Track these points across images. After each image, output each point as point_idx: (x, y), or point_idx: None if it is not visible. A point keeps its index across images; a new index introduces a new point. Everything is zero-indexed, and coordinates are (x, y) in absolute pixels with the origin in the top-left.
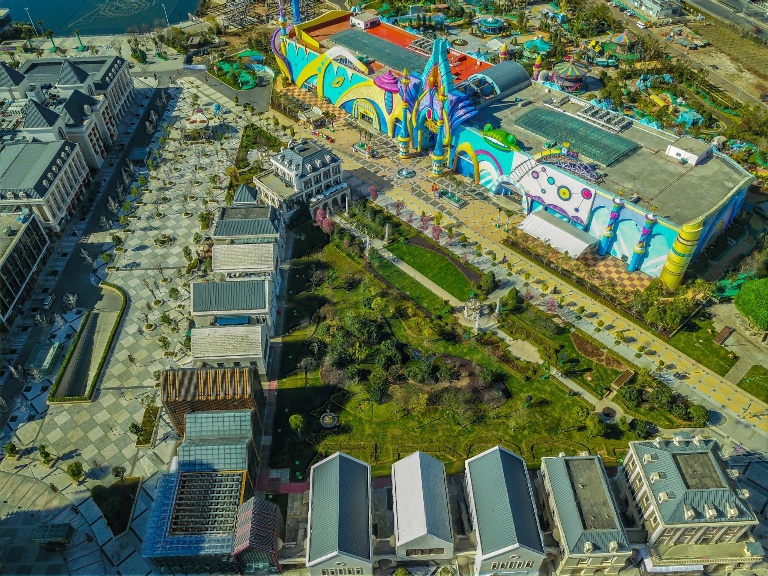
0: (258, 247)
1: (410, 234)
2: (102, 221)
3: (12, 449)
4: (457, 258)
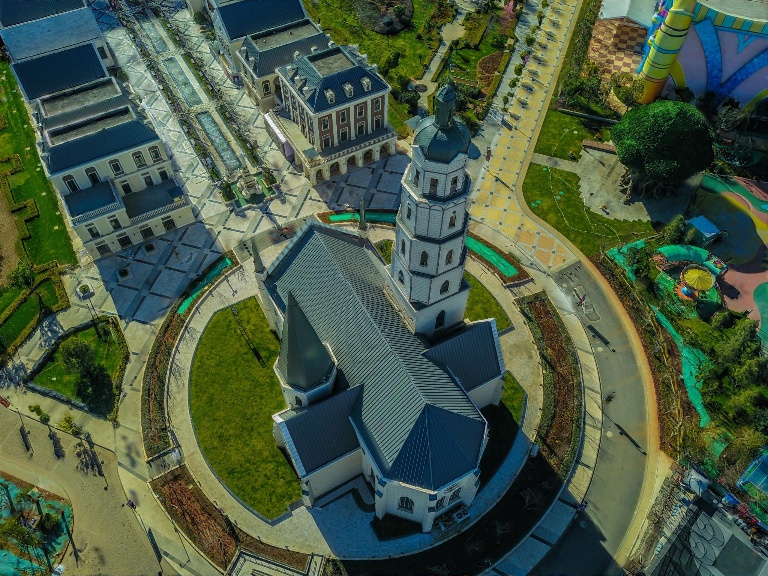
0: None
1: None
2: None
3: None
4: None
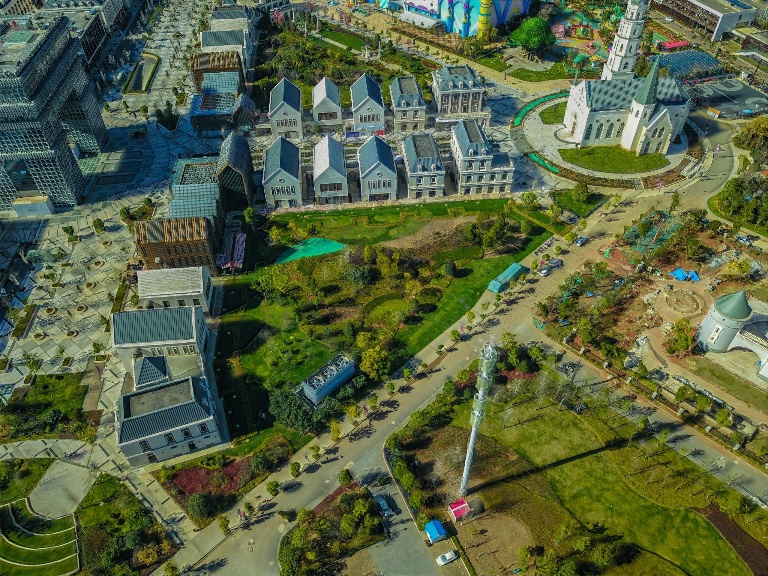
0: (238, 20)
1: (333, 27)
2: (138, 24)
3: (107, 106)
4: (360, 35)
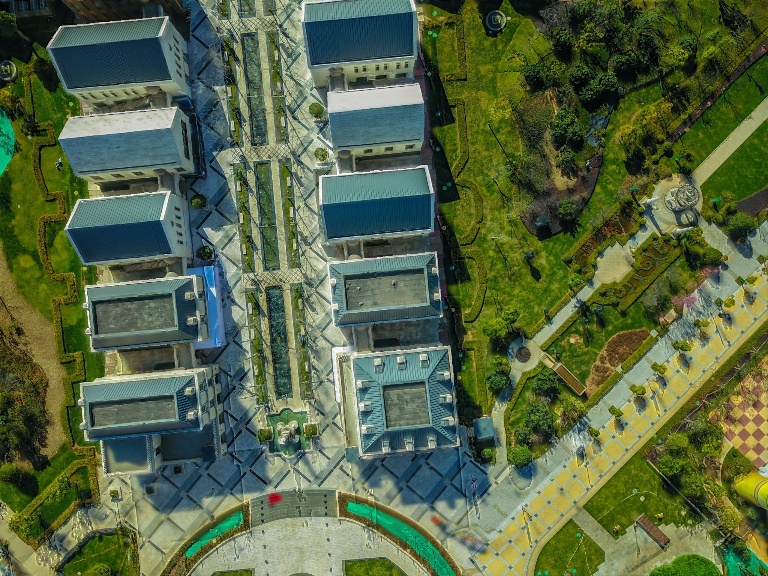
0: None
1: None
2: None
3: None
4: None
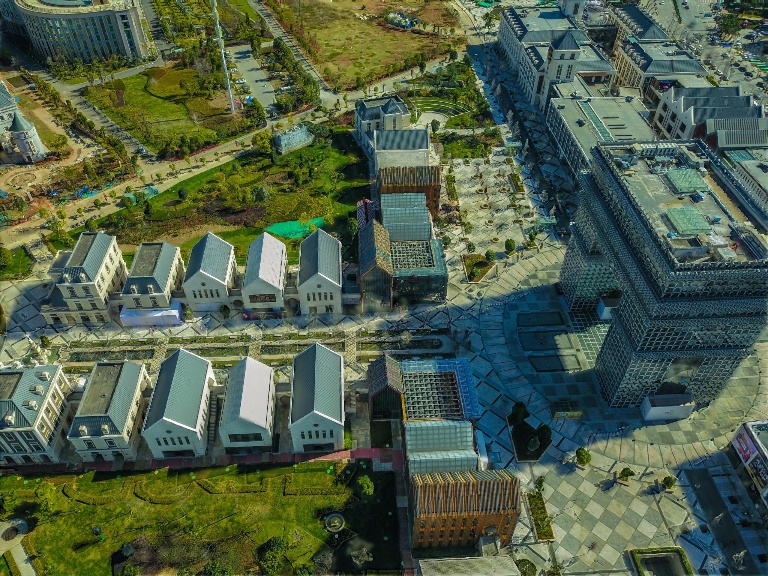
0: None
1: None
2: None
3: None
4: None
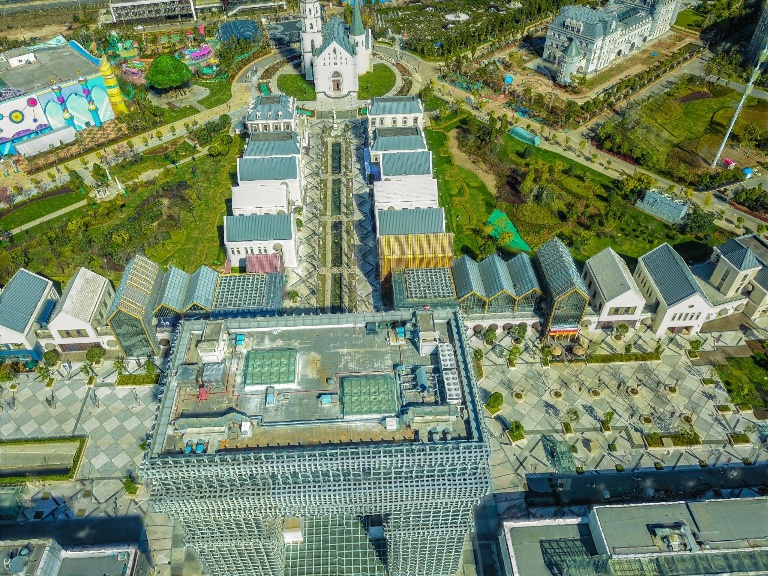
0: None
1: None
2: None
3: (132, 482)
4: (34, 197)
